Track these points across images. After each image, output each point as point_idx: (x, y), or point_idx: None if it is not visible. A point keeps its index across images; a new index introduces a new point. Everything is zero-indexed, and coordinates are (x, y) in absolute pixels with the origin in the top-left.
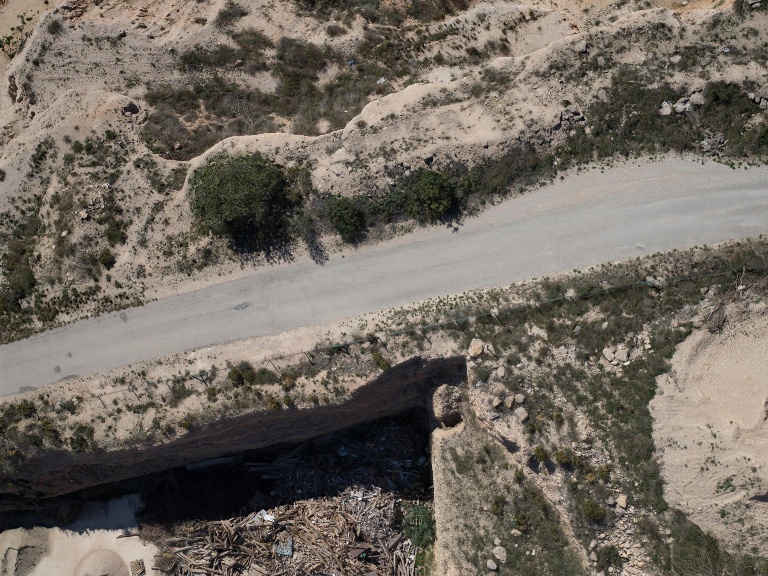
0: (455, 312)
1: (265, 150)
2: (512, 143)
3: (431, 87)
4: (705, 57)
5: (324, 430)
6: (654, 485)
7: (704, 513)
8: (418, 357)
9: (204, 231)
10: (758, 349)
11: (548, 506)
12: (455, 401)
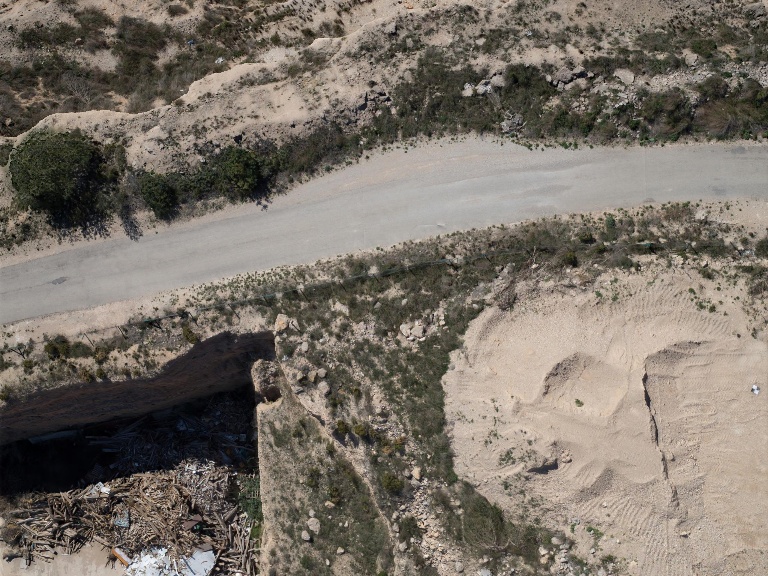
0: (263, 288)
1: (85, 127)
2: (318, 122)
3: (251, 67)
4: (509, 40)
5: (153, 404)
6: (444, 458)
7: (490, 485)
8: (228, 332)
9: (23, 206)
10: (546, 326)
11: (358, 479)
12: (272, 376)
